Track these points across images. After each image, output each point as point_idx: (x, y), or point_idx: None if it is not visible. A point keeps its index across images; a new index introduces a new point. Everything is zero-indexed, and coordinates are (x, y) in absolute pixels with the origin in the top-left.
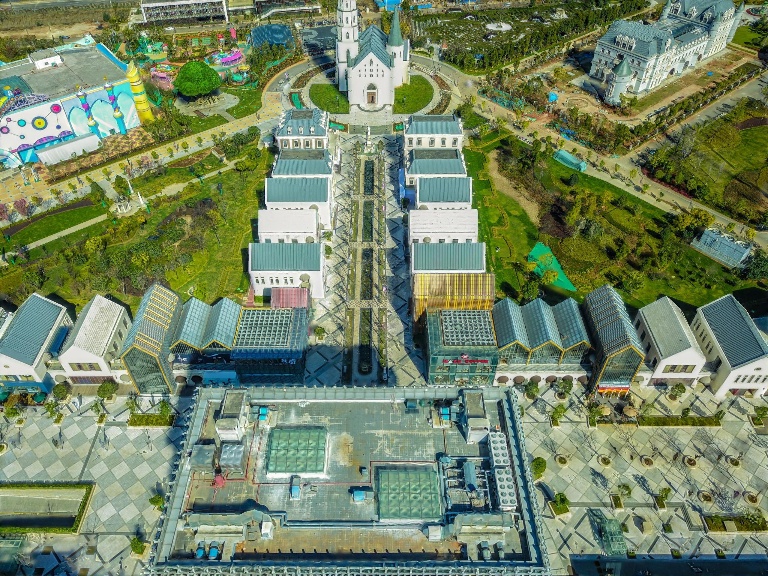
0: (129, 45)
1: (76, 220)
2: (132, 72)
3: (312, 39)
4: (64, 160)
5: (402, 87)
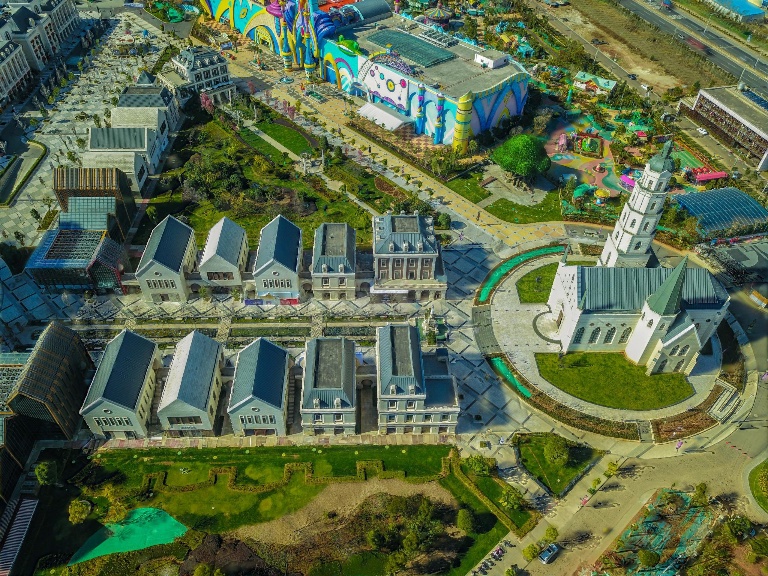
0: (620, 110)
1: (292, 146)
2: (462, 99)
3: (761, 253)
4: (367, 118)
5: (632, 364)
